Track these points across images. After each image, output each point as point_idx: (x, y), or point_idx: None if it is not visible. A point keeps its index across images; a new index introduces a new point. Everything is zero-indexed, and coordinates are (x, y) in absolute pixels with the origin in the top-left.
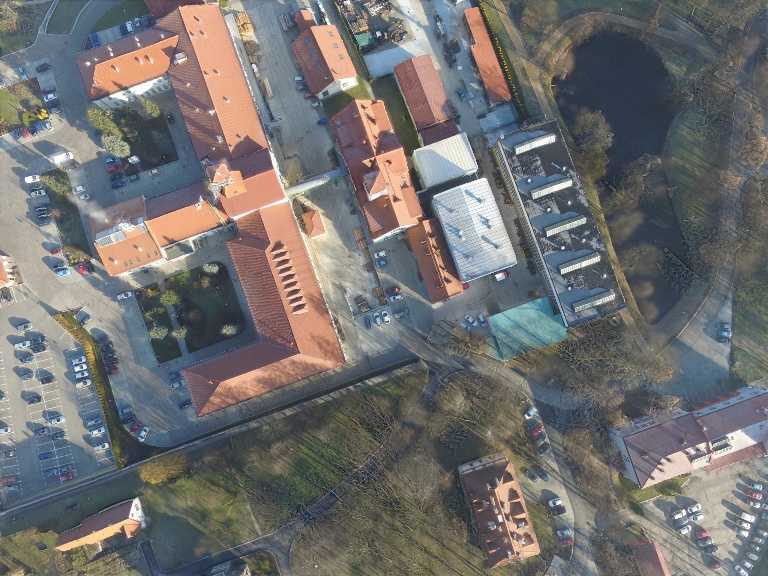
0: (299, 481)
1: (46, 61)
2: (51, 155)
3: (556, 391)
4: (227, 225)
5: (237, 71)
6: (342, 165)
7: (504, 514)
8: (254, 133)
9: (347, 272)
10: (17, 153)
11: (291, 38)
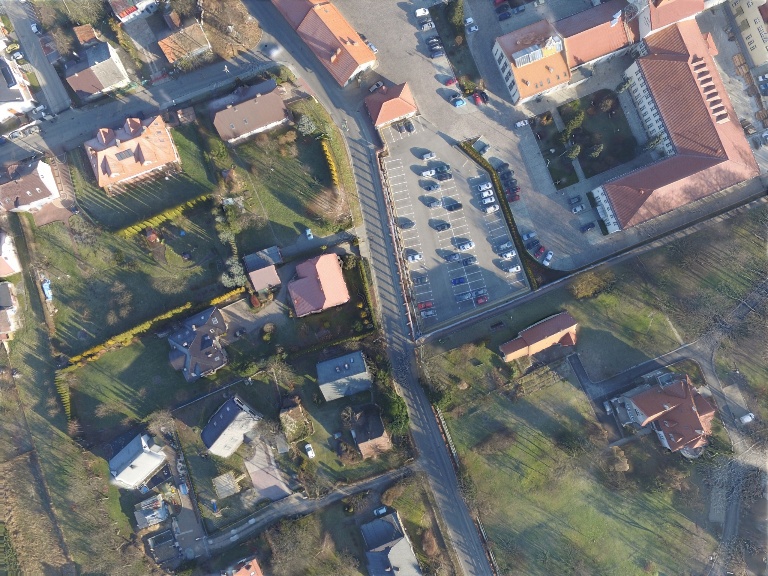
0: (712, 293)
1: None
2: None
3: None
4: (631, 46)
5: None
6: None
7: None
8: None
9: None
10: None
11: None
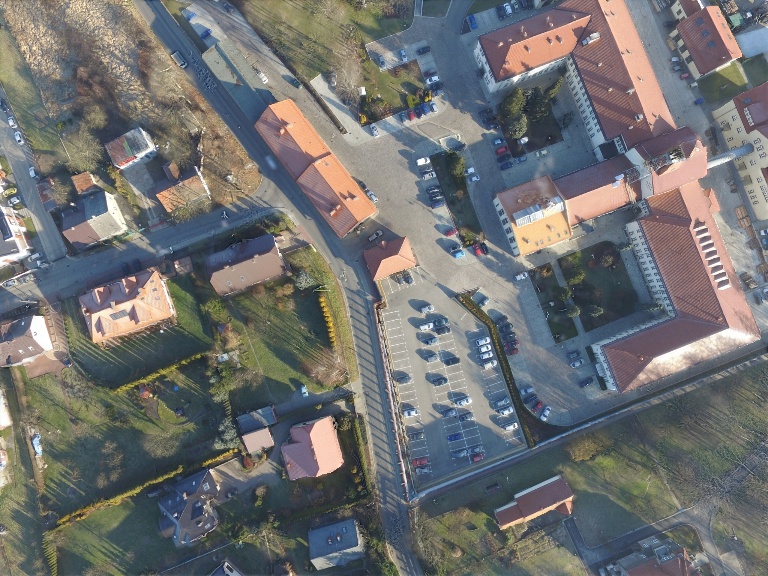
0: (711, 455)
1: (424, 43)
2: (437, 137)
3: None
4: None
5: (642, 51)
6: (725, 144)
7: None
8: (663, 112)
9: (730, 250)
10: (402, 136)
11: (663, 19)
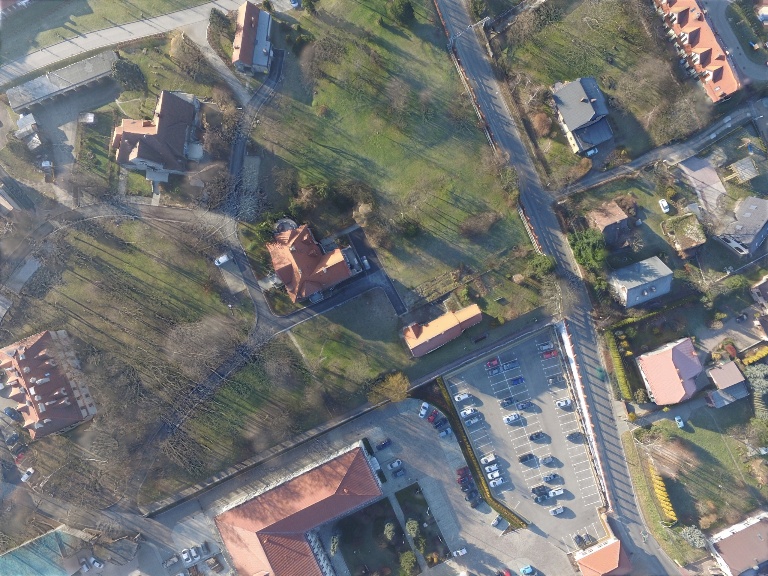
0: (257, 385)
1: None
2: None
3: (4, 498)
4: None
5: None
6: None
7: (29, 396)
8: None
9: None
10: None
11: None
